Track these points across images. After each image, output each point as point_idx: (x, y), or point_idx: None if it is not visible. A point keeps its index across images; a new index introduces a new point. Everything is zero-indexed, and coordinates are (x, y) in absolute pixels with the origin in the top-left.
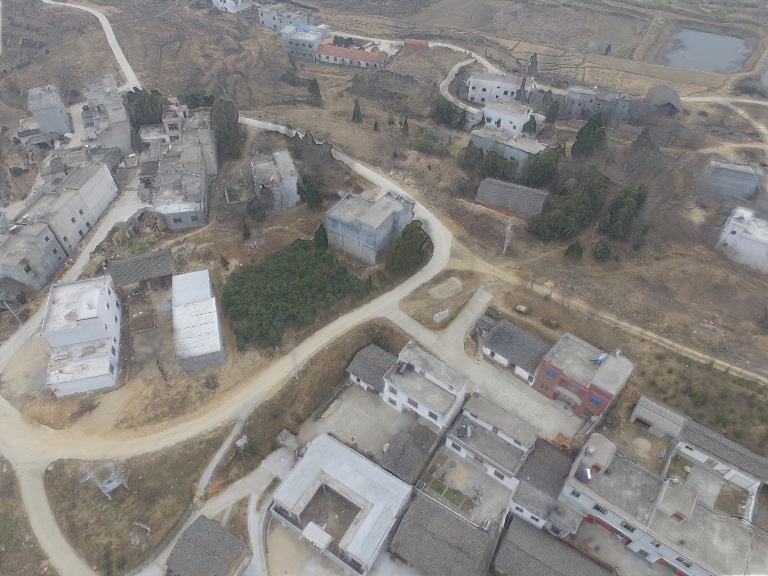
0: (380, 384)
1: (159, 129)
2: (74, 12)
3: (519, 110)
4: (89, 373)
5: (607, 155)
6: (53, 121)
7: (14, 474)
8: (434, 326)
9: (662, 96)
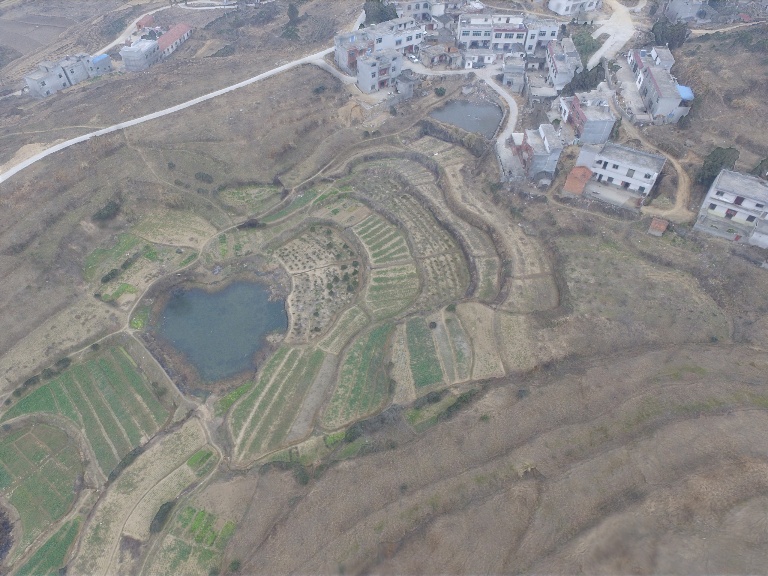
0: None
1: None
2: (30, 175)
3: None
4: None
5: None
6: None
7: None
8: None
9: None
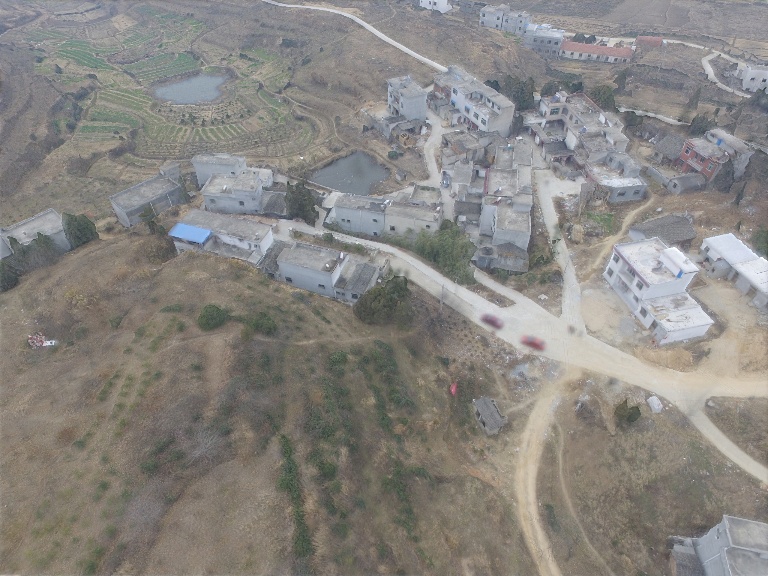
0: None
1: (535, 114)
2: (322, 14)
3: None
4: (696, 322)
5: None
6: (418, 108)
7: (678, 409)
8: None
9: None
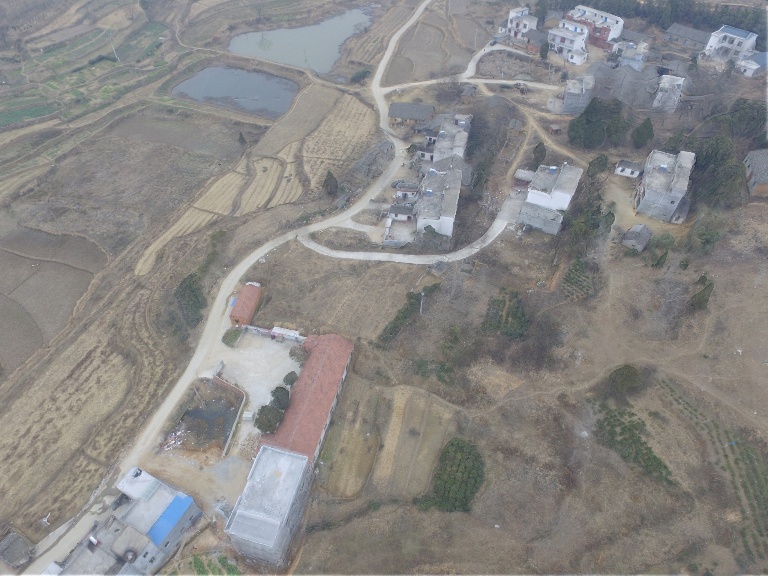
0: None
1: None
2: None
3: (568, 170)
4: None
5: (636, 125)
6: None
7: None
8: None
9: (418, 107)
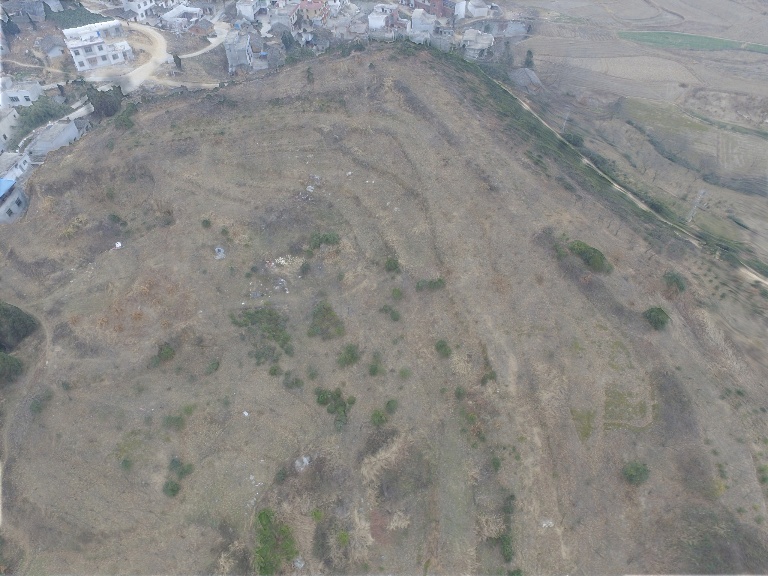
0: (135, 13)
1: None
2: None
3: None
4: (125, 44)
5: None
6: None
7: None
8: (106, 6)
9: None
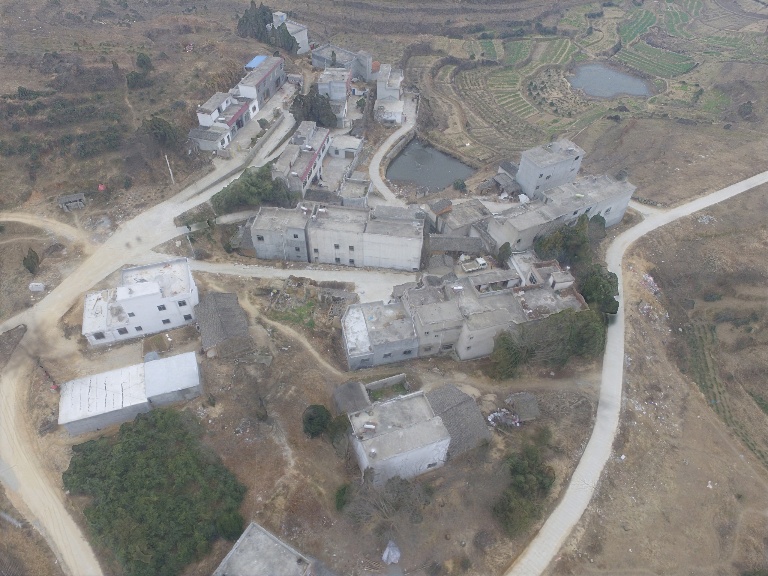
0: None
1: None
2: None
3: None
4: (89, 320)
5: None
6: (529, 177)
7: (30, 306)
8: None
9: None
